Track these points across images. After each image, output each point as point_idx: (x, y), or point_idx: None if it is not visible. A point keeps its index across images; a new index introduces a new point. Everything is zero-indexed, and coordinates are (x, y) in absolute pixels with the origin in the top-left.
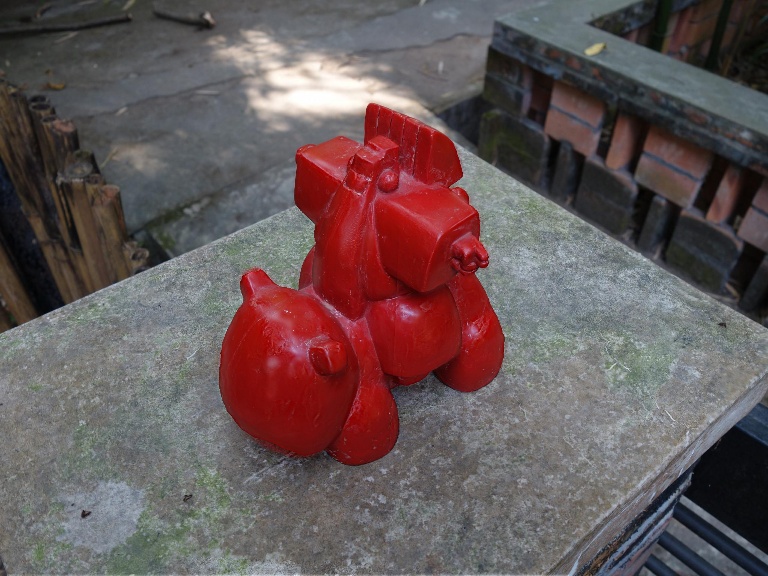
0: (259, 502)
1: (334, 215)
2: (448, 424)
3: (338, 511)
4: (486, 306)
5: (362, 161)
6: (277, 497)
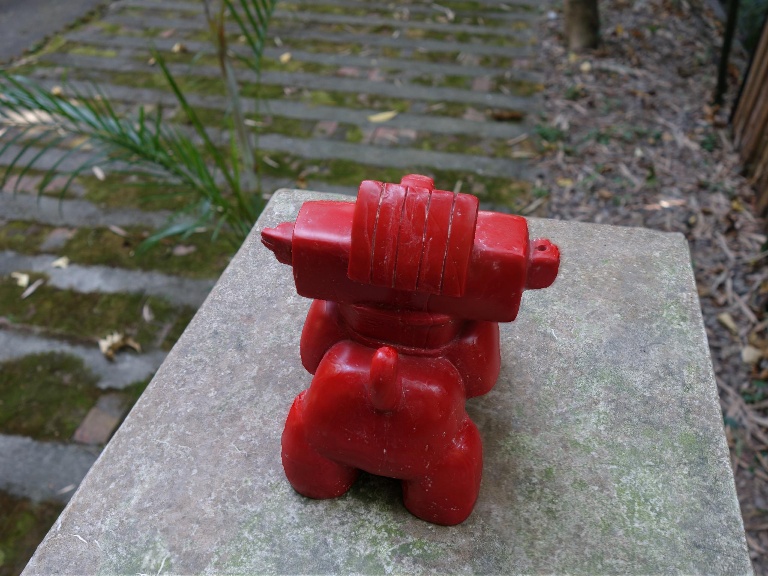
0: None
1: None
2: None
3: None
4: None
5: None
6: None
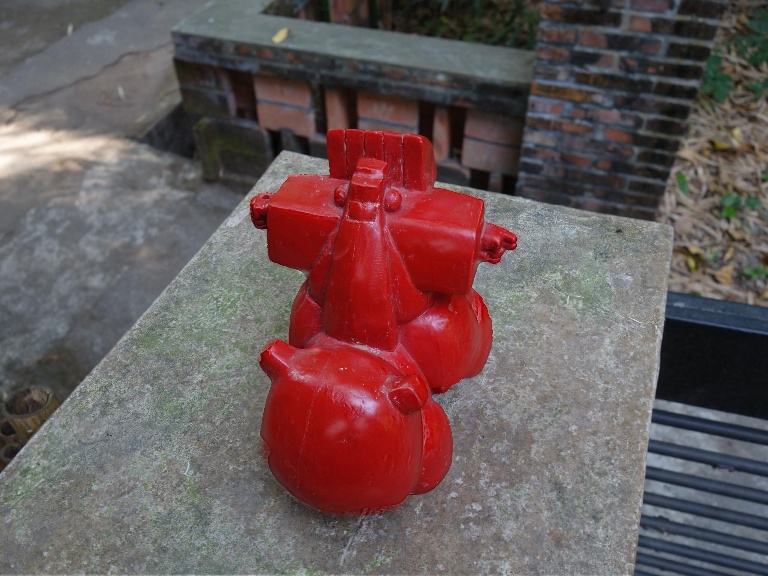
0: (370, 574)
1: (350, 253)
2: (481, 411)
3: (448, 539)
4: (472, 289)
5: (365, 189)
6: (383, 559)
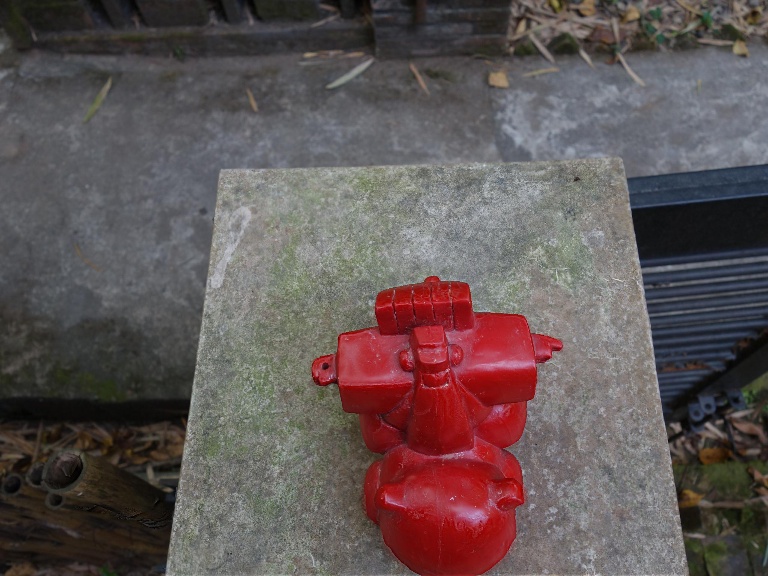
0: None
1: (433, 412)
2: (526, 420)
3: (542, 546)
4: None
5: (436, 365)
6: None
